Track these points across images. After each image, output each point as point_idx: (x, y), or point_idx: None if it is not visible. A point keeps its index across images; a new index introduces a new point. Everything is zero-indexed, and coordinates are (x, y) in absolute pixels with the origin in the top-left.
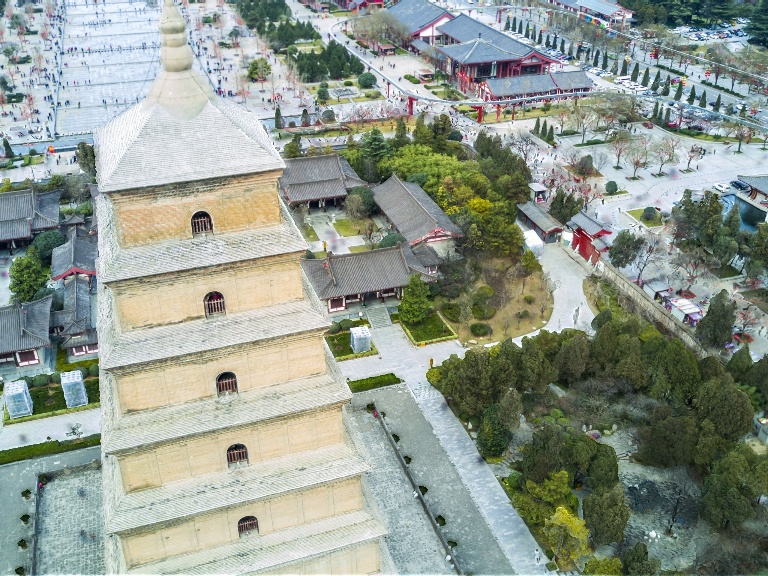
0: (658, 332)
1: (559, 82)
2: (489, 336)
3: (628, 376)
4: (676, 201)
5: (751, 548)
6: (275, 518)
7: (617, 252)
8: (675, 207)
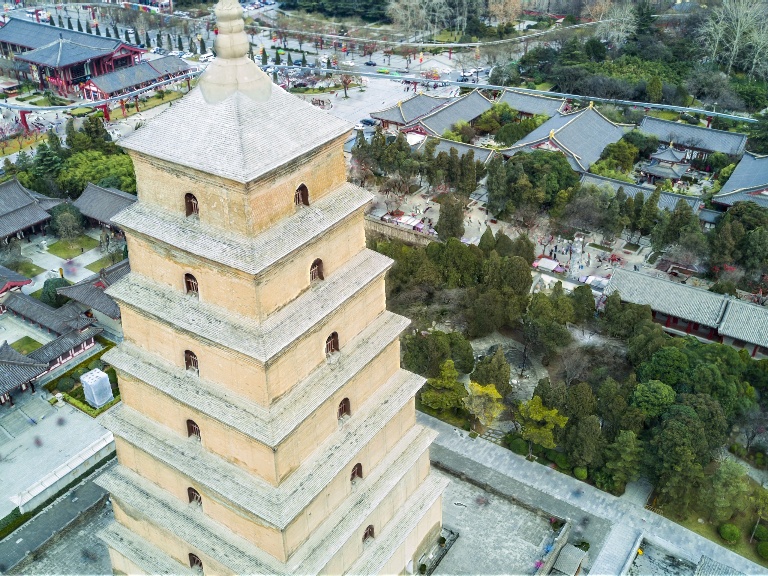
0: (405, 246)
1: (159, 68)
2: None
3: (428, 279)
4: None
5: (584, 357)
6: (371, 458)
7: None
8: (354, 147)
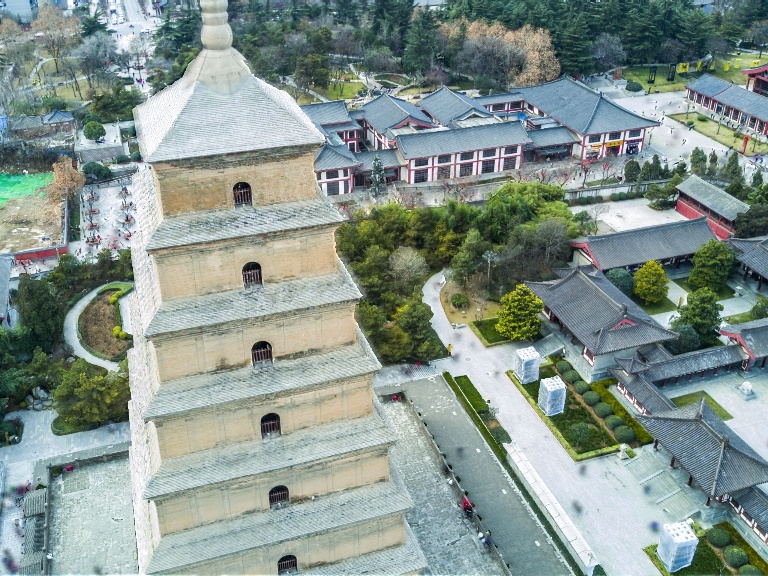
0: None
1: None
2: None
3: None
4: None
5: None
6: None
7: None
8: None
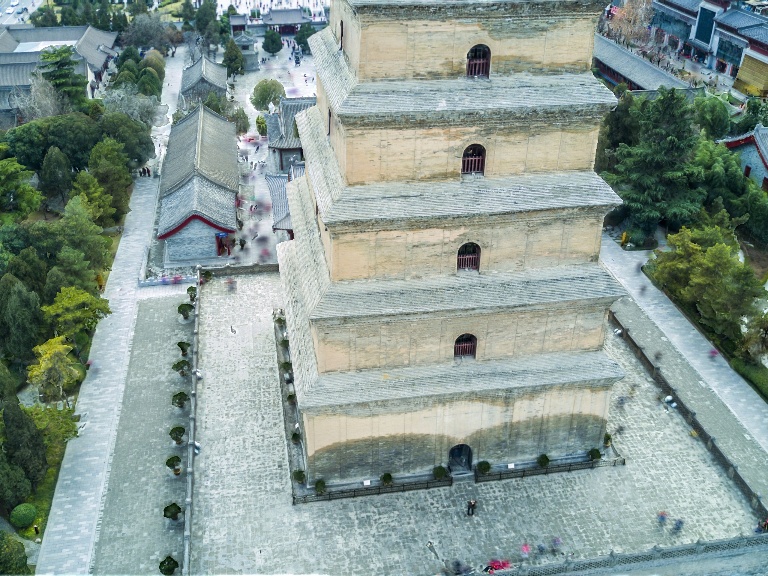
0: None
1: None
2: None
3: None
4: None
5: None
6: None
7: None
8: None
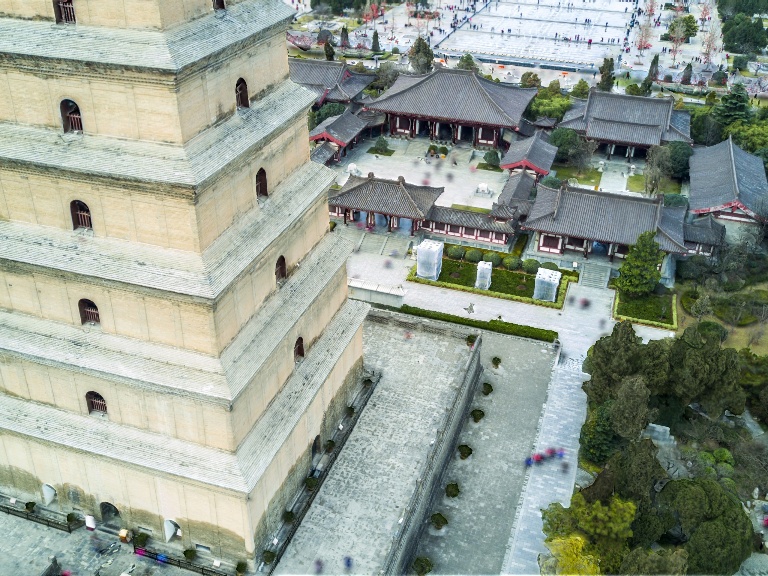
0: None
1: None
2: (720, 343)
3: None
4: None
5: None
6: (117, 317)
7: None
8: None
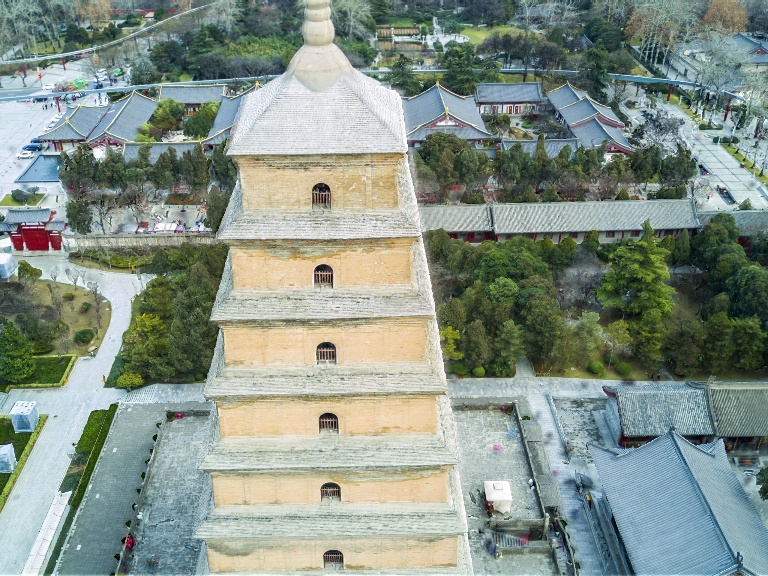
0: None
1: None
2: (96, 336)
3: None
4: (15, 180)
5: None
6: None
7: (79, 222)
8: (61, 172)
